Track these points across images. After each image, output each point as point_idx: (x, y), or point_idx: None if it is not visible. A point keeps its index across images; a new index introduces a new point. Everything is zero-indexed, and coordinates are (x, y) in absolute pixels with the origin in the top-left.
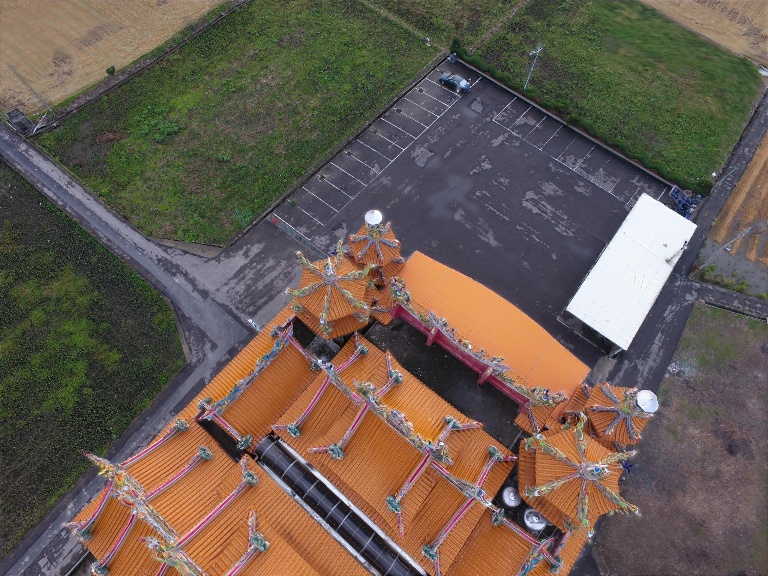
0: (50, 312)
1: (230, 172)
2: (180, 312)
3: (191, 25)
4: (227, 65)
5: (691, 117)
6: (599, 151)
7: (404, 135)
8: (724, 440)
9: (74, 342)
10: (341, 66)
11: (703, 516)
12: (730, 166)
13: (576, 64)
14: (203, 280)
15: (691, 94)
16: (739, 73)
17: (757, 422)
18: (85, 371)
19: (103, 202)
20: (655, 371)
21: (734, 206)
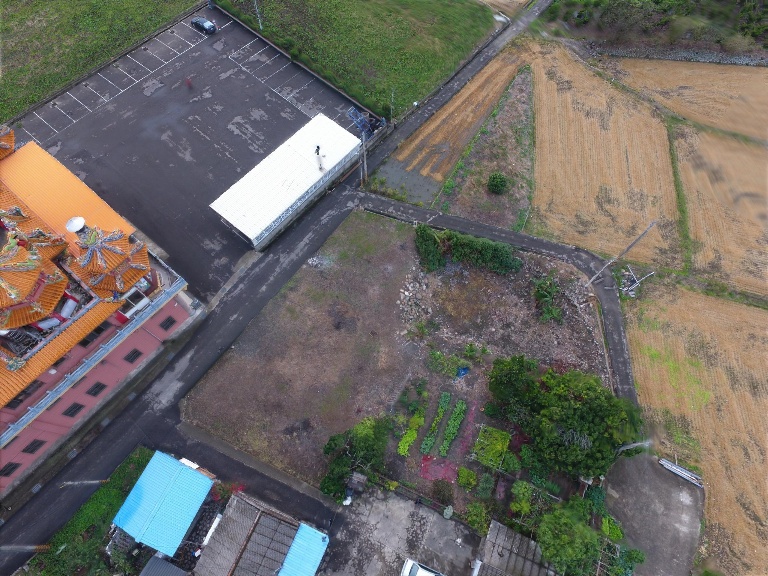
0: None
1: None
2: None
3: None
4: (2, 10)
5: (414, 55)
6: (316, 83)
7: (142, 69)
8: (335, 318)
9: None
10: (105, 11)
11: (291, 377)
12: (435, 97)
13: (327, 10)
14: None
15: (423, 36)
16: (475, 18)
17: (371, 304)
18: None
19: None
20: (294, 263)
21: (426, 131)
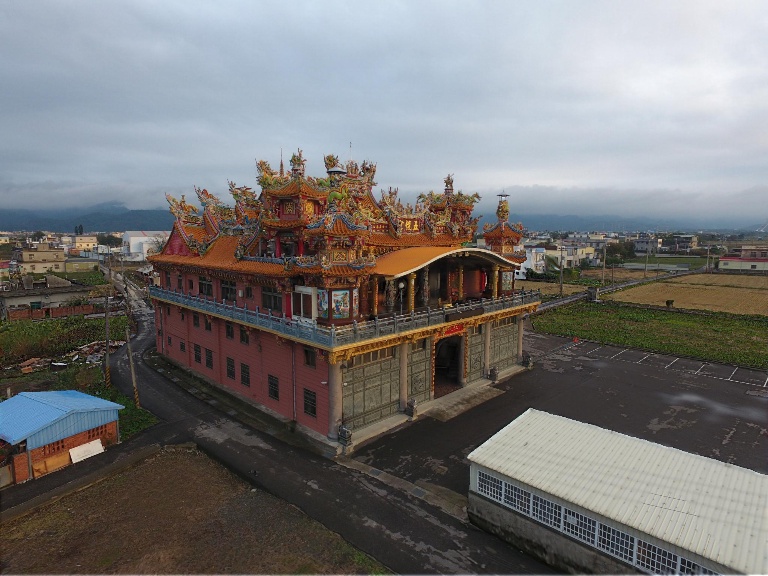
0: None
1: None
2: None
3: None
4: None
5: None
6: None
7: None
8: None
9: None
10: None
11: (120, 575)
12: None
13: None
14: None
15: None
16: None
17: None
18: None
19: None
20: None
21: None
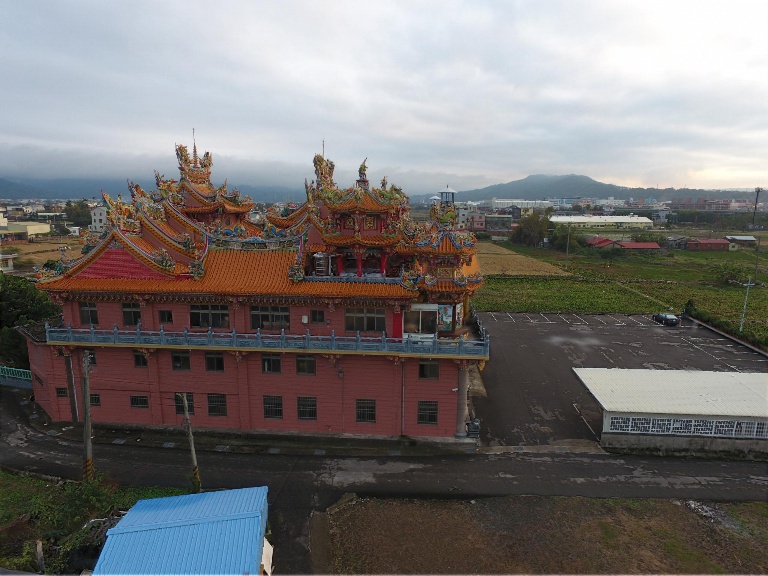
0: None
1: None
2: None
3: (505, 274)
4: None
5: None
6: None
7: None
8: None
9: None
10: None
11: None
12: None
13: None
14: None
15: None
16: None
17: None
18: None
19: None
20: (658, 487)
21: None
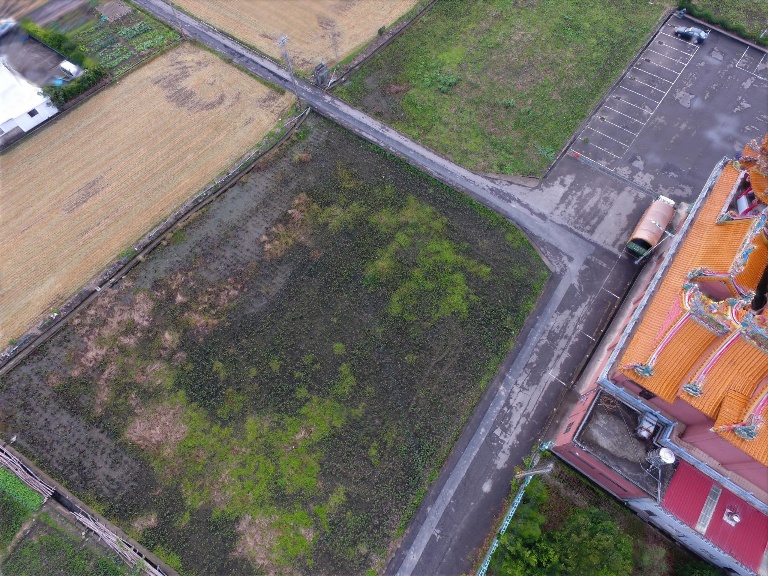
0: (412, 235)
1: (519, 116)
2: (528, 231)
3: None
4: (476, 25)
5: None
6: None
7: (661, 81)
8: None
9: (444, 259)
10: (581, 23)
11: None
12: None
13: None
14: (536, 205)
15: None
16: None
17: None
18: (464, 282)
19: (421, 143)
20: None
21: None
